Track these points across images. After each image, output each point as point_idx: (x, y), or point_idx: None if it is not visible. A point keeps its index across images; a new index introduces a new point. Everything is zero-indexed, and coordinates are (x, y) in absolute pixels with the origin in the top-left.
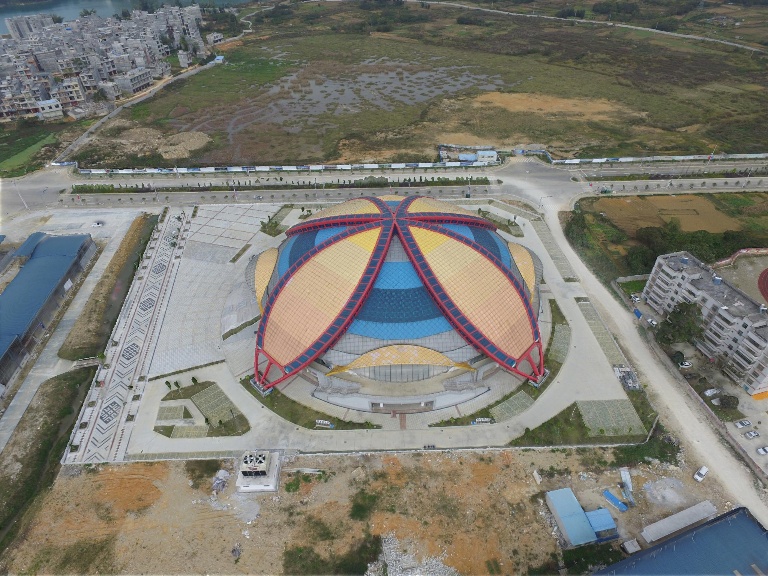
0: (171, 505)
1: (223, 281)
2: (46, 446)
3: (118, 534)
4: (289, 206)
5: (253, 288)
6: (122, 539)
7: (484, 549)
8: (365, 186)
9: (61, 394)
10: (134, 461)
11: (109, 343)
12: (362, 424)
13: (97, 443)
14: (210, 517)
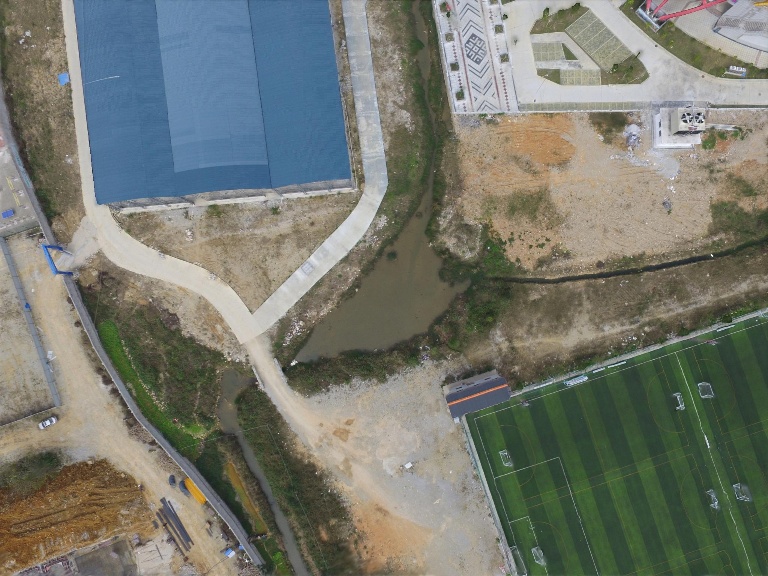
0: (590, 160)
1: None
2: (419, 91)
3: (549, 186)
4: None
5: None
6: (555, 191)
7: None
8: None
9: (400, 21)
10: (533, 112)
11: None
12: None
13: (480, 89)
14: (633, 172)
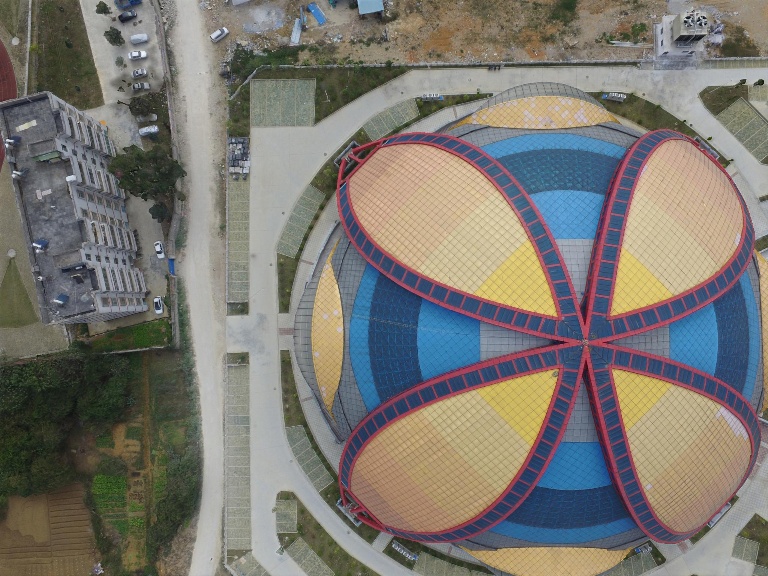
0: (759, 10)
1: None
2: None
3: None
4: None
5: None
6: None
7: None
8: None
9: None
10: None
11: None
12: None
13: None
14: None
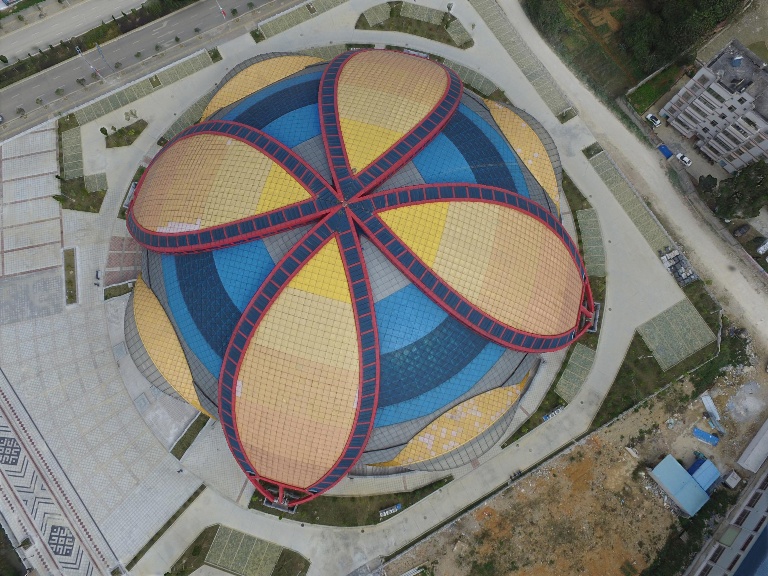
0: None
1: (89, 348)
2: None
3: None
4: (68, 122)
5: (173, 393)
6: None
7: (614, 557)
8: (167, 9)
9: None
10: None
11: (16, 547)
12: (431, 486)
13: None
14: None
